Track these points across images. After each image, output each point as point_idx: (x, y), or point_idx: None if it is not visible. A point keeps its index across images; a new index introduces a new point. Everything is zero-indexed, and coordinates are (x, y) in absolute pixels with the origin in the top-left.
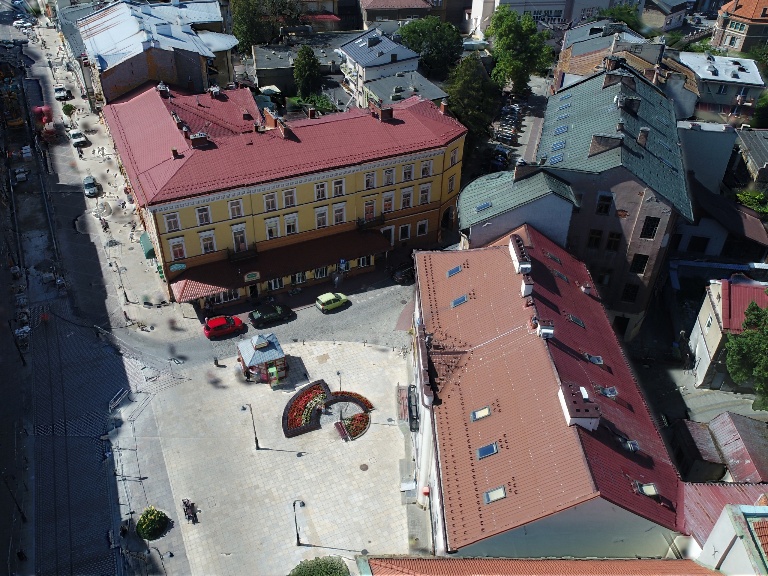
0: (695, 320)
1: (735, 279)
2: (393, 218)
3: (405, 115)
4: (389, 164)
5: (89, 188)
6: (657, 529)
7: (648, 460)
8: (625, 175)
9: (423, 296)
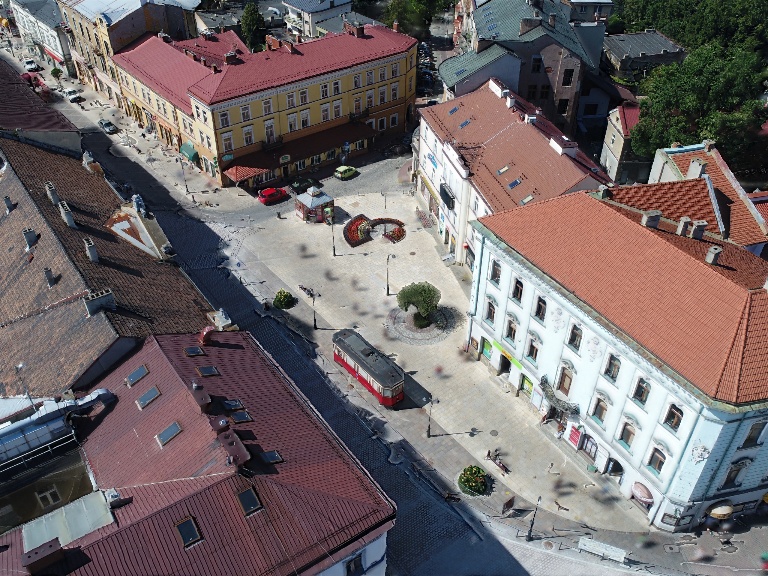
0: (603, 144)
1: (626, 105)
2: (374, 112)
3: (372, 32)
4: (370, 67)
5: (108, 127)
6: None
7: None
8: (549, 41)
9: (436, 129)
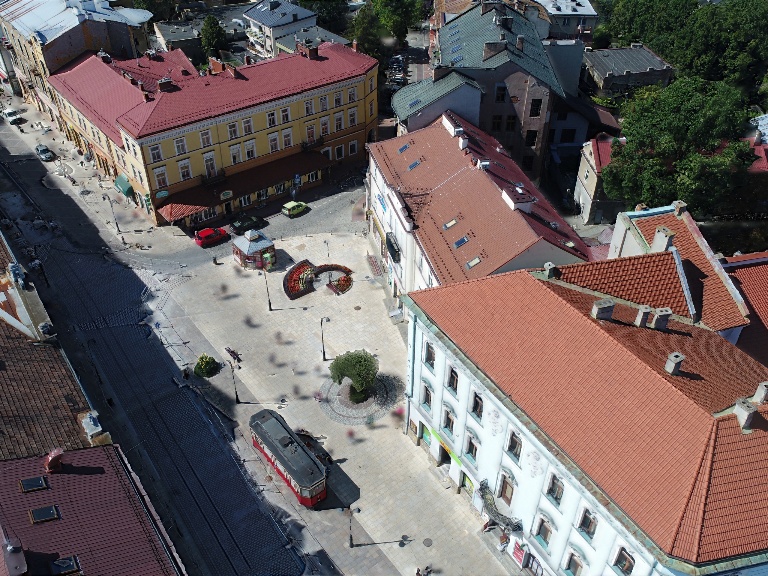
0: (576, 179)
1: (600, 138)
2: (330, 140)
3: (328, 53)
4: (323, 92)
5: (44, 153)
6: (579, 262)
7: (565, 235)
8: (514, 68)
9: (384, 170)
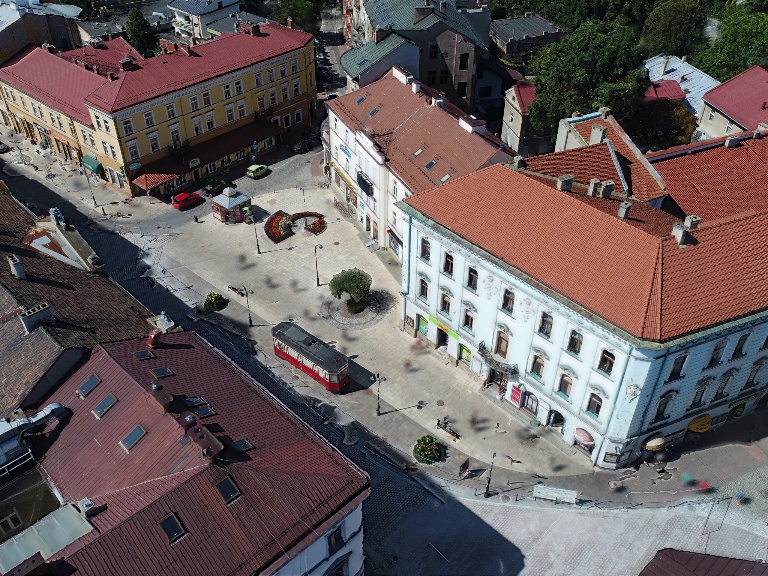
0: (502, 123)
1: (520, 84)
2: (278, 109)
3: (268, 30)
4: (270, 65)
5: None
6: None
7: (512, 153)
8: (443, 27)
9: (346, 120)
